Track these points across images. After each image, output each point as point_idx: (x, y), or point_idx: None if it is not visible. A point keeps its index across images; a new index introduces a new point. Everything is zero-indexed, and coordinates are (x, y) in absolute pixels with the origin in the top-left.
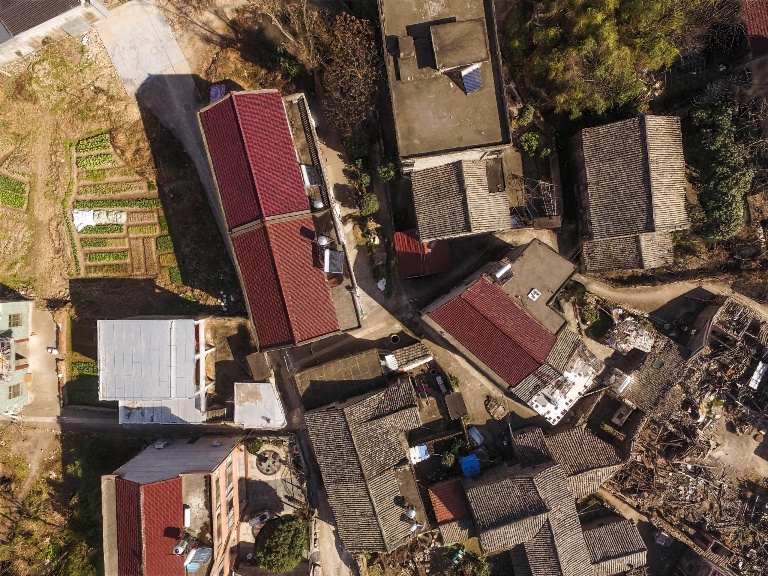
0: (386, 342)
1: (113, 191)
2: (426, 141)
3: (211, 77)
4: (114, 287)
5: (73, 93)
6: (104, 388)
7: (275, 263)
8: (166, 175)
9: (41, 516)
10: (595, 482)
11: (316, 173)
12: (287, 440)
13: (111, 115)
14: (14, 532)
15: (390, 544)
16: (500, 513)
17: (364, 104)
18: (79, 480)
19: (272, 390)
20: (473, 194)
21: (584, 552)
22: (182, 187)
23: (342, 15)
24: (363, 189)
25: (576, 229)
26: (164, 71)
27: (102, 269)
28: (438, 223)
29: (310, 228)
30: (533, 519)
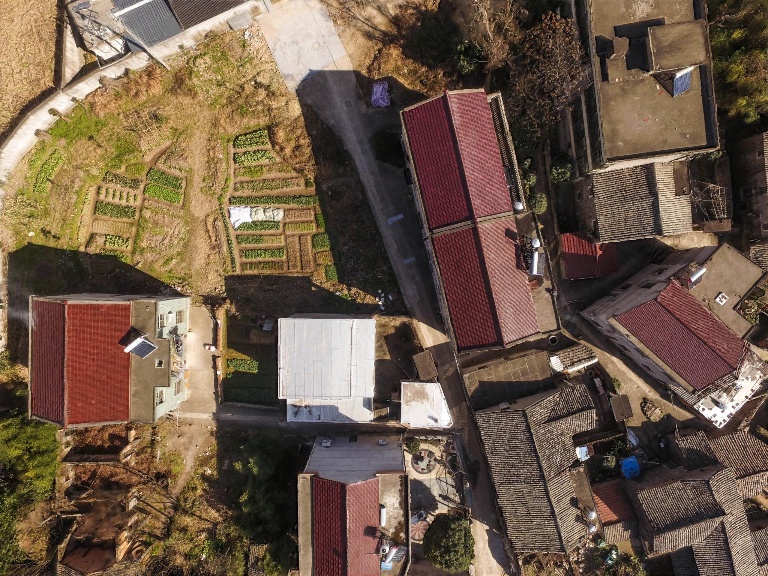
0: (544, 343)
1: (270, 188)
2: (630, 143)
3: (374, 74)
4: (271, 284)
5: (232, 88)
6: (284, 386)
7: (486, 265)
8: (326, 172)
9: (196, 512)
10: (759, 485)
11: (508, 174)
12: (445, 439)
13: (272, 111)
14: (168, 527)
15: (567, 545)
16: (674, 515)
17: (562, 105)
18: (234, 476)
19: (439, 390)
20: (663, 197)
21: (752, 554)
22: (342, 185)
23: (548, 14)
24: (526, 189)
25: (740, 232)
26: (326, 67)
27: (258, 266)
28: (622, 225)
29: (513, 230)
30: (708, 521)
